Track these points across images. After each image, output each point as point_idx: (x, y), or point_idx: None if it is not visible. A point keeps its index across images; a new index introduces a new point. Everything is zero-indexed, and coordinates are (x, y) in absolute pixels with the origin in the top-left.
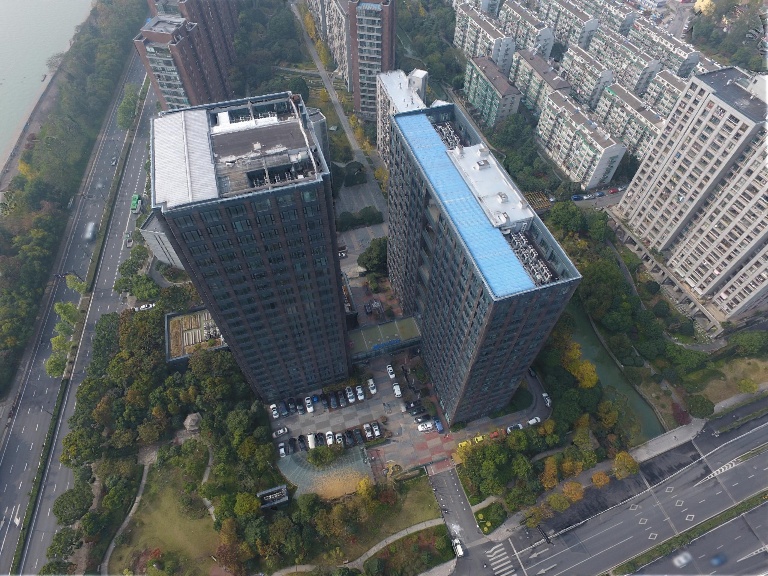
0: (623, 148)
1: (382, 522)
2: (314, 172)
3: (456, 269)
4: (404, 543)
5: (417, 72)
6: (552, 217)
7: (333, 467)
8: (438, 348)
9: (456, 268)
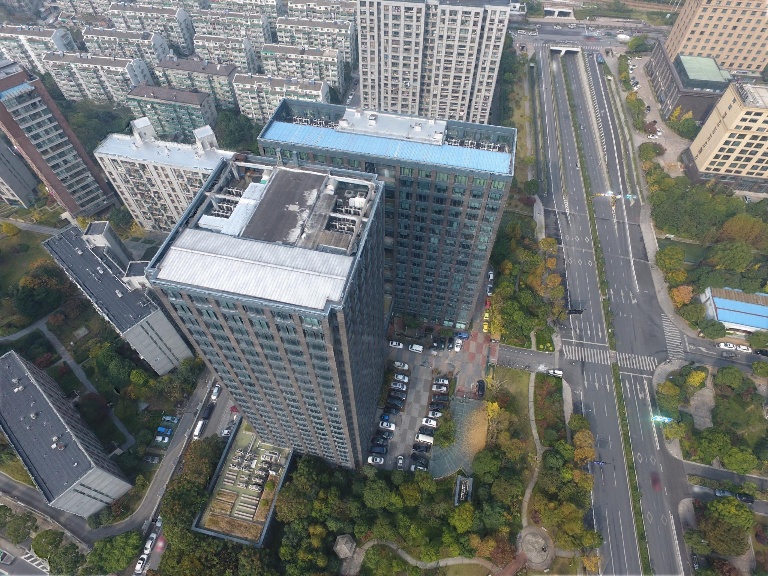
0: (326, 83)
1: (518, 415)
2: (349, 191)
3: (444, 194)
4: (539, 407)
5: (137, 123)
6: None
7: (460, 429)
8: (429, 282)
9: (443, 194)
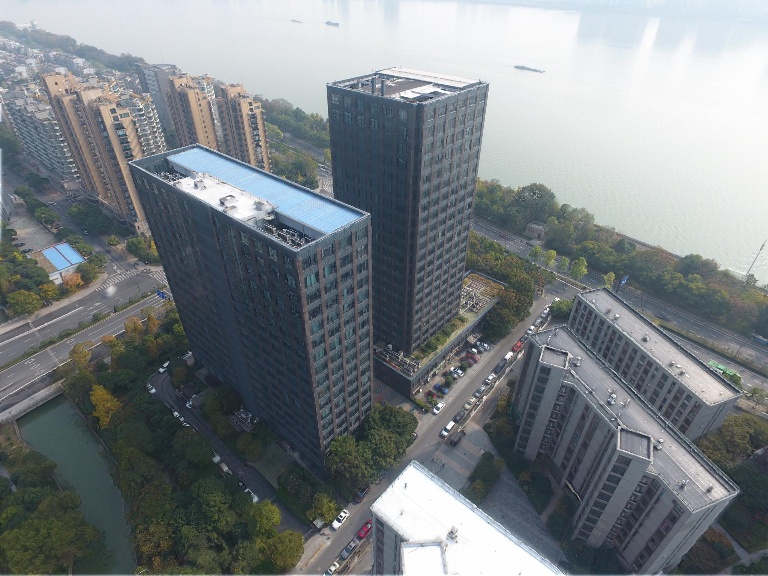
0: None
1: None
2: None
3: None
4: None
5: None
6: None
7: None
8: None
9: None
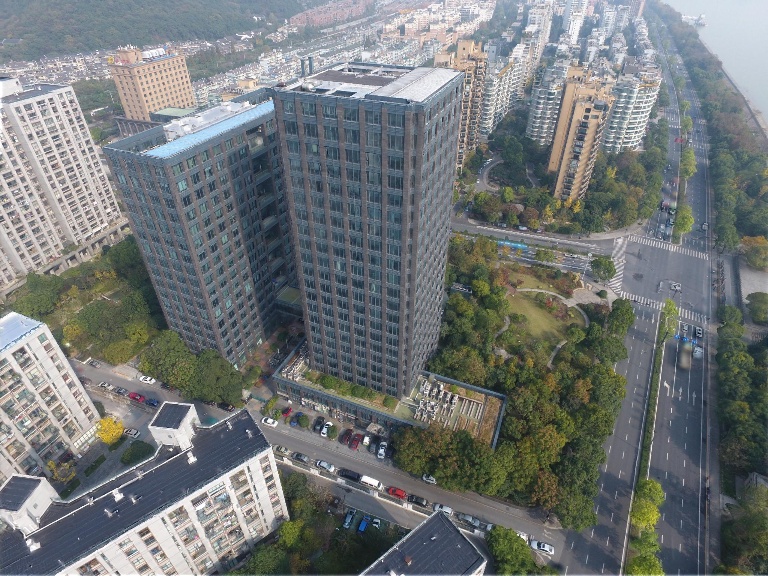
0: None
1: None
2: None
3: None
4: None
5: None
6: None
7: None
8: None
9: None
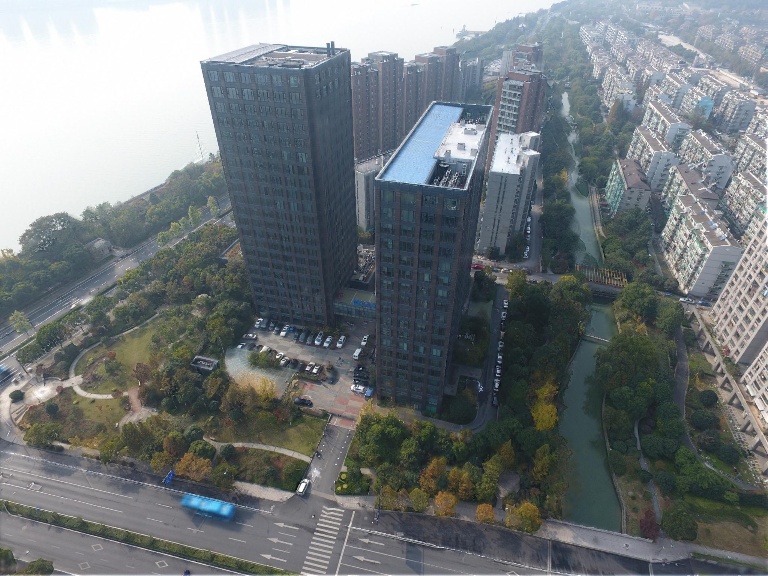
0: None
1: (262, 429)
2: None
3: None
4: None
5: (531, 134)
6: (622, 297)
7: (261, 371)
8: None
9: None
